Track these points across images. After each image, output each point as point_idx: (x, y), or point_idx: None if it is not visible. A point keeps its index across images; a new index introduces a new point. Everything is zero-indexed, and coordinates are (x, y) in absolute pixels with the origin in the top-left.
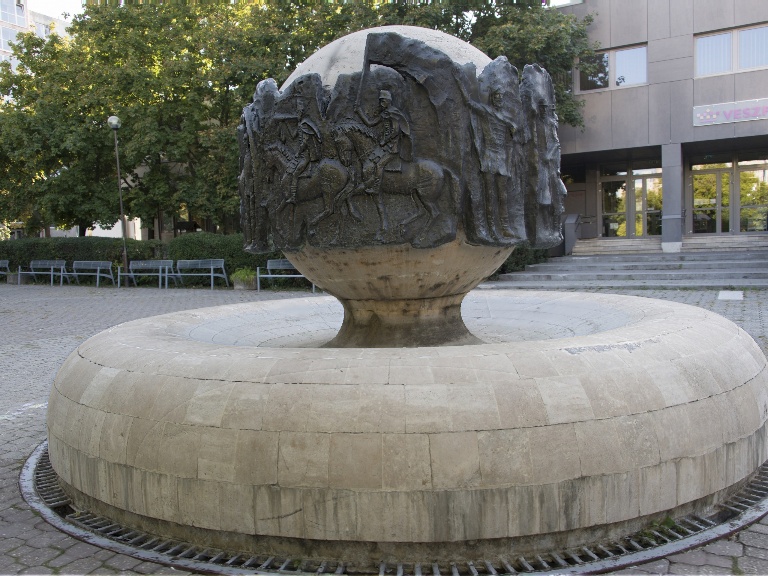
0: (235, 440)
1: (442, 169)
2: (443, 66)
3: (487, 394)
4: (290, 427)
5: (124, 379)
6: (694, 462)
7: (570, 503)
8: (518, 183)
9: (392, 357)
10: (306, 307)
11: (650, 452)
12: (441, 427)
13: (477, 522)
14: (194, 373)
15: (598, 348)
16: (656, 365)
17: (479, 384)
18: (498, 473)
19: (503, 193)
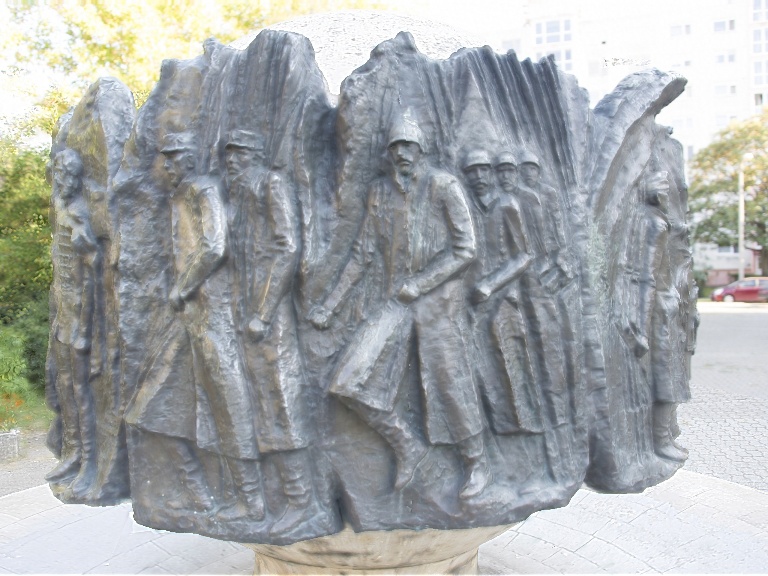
0: None
1: None
2: None
3: None
4: None
5: None
6: None
7: None
8: (109, 360)
9: None
10: None
11: None
12: None
13: None
14: None
15: None
16: None
17: None
18: None
19: None
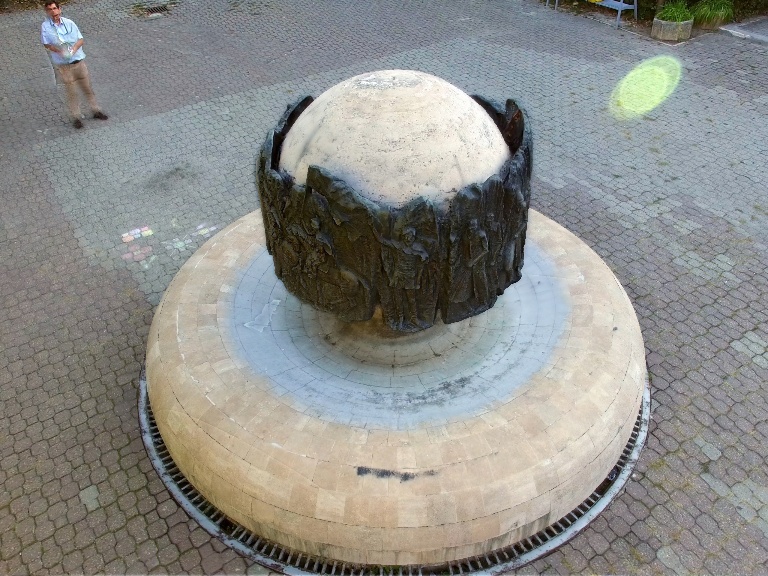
0: (180, 447)
1: (358, 280)
2: (359, 212)
3: (288, 489)
4: (199, 458)
5: (157, 366)
6: (412, 553)
7: (322, 550)
8: (431, 288)
9: (260, 436)
10: None
11: (376, 546)
12: (259, 497)
13: (274, 537)
14: (177, 391)
15: (381, 473)
16: (410, 498)
17: (287, 481)
18: (283, 527)
19: (410, 298)
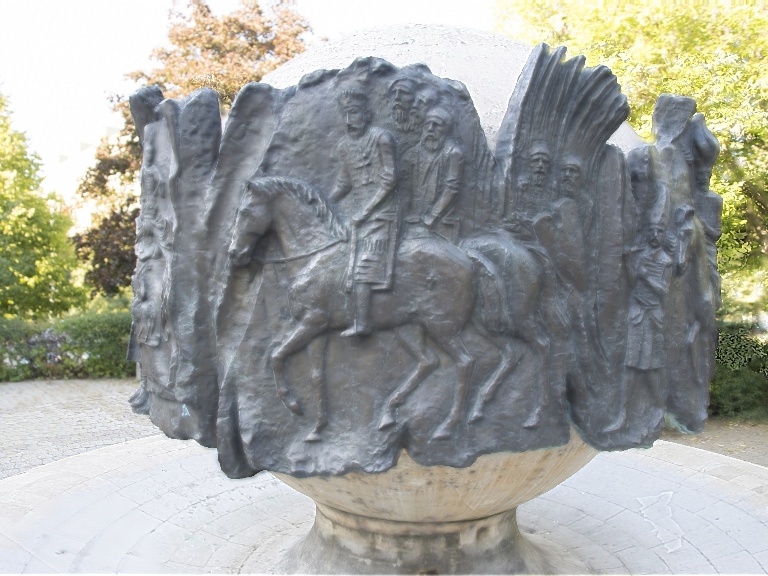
0: None
1: None
2: None
3: None
4: None
5: None
6: None
7: None
8: None
9: None
10: None
11: None
12: None
13: None
14: None
15: None
16: None
17: None
18: None
19: None
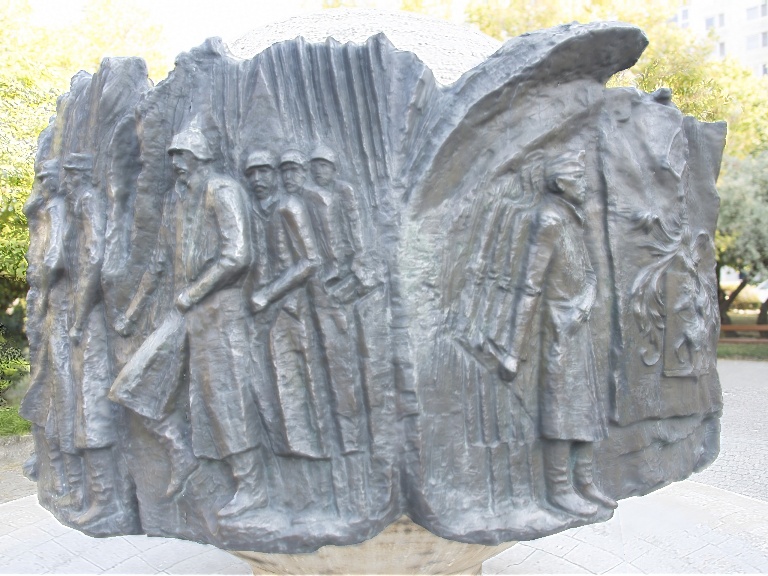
0: None
1: None
2: None
3: None
4: None
5: None
6: None
7: None
8: None
9: None
10: (681, 523)
11: None
12: None
13: None
14: None
15: None
16: None
17: None
18: None
19: None
